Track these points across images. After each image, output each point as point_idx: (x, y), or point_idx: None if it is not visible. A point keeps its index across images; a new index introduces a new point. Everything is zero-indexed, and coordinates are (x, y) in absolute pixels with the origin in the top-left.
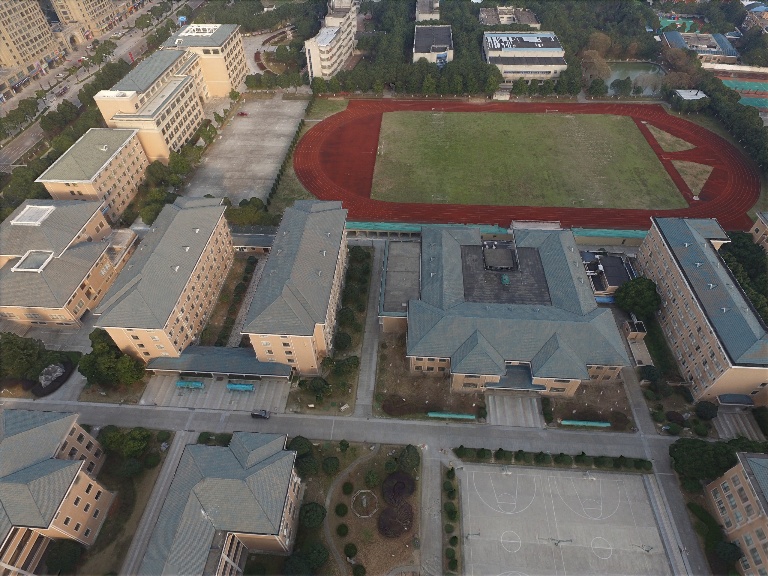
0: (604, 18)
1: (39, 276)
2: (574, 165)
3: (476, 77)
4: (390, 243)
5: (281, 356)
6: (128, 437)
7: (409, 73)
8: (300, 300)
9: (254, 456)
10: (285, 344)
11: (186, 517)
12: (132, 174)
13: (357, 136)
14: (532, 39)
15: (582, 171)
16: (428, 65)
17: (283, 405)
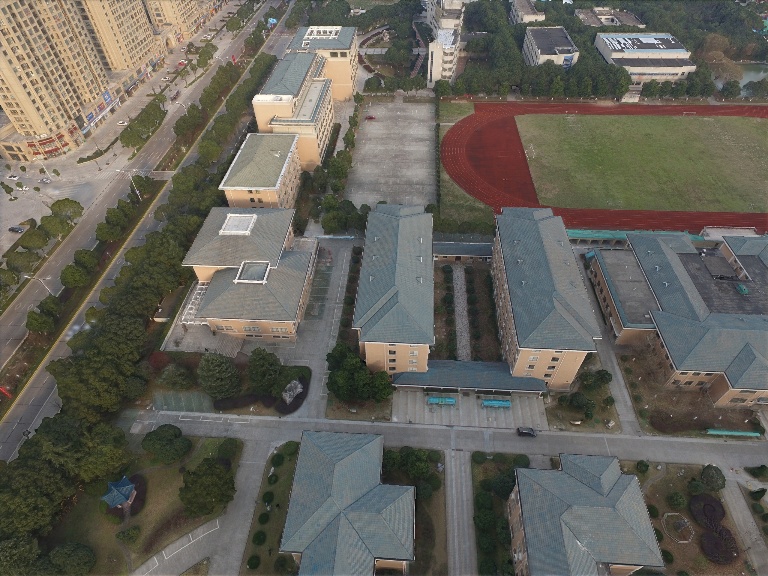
0: (701, 19)
1: (264, 288)
2: (736, 169)
3: (605, 79)
4: (600, 251)
5: (540, 371)
6: (413, 458)
7: (535, 75)
8: (572, 313)
9: (605, 481)
10: (554, 359)
11: (569, 549)
12: (293, 180)
13: (498, 140)
14: (650, 40)
15: (747, 175)
16: (556, 67)
17: (545, 422)
